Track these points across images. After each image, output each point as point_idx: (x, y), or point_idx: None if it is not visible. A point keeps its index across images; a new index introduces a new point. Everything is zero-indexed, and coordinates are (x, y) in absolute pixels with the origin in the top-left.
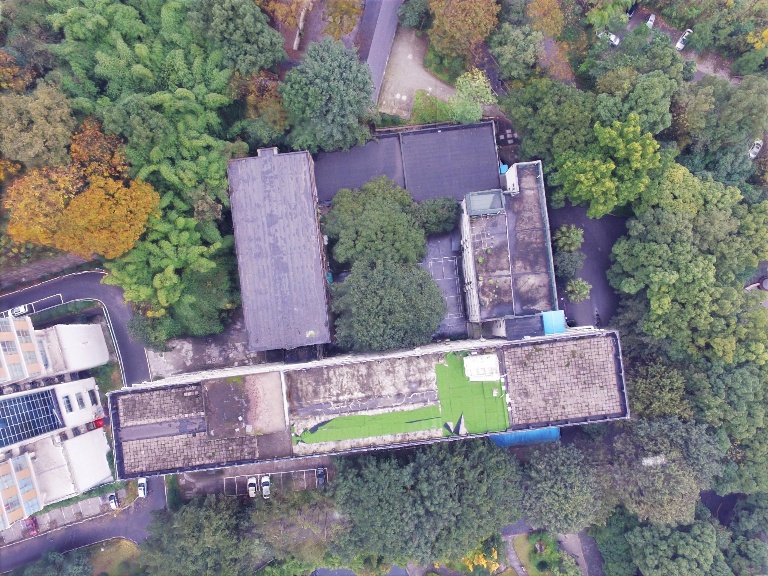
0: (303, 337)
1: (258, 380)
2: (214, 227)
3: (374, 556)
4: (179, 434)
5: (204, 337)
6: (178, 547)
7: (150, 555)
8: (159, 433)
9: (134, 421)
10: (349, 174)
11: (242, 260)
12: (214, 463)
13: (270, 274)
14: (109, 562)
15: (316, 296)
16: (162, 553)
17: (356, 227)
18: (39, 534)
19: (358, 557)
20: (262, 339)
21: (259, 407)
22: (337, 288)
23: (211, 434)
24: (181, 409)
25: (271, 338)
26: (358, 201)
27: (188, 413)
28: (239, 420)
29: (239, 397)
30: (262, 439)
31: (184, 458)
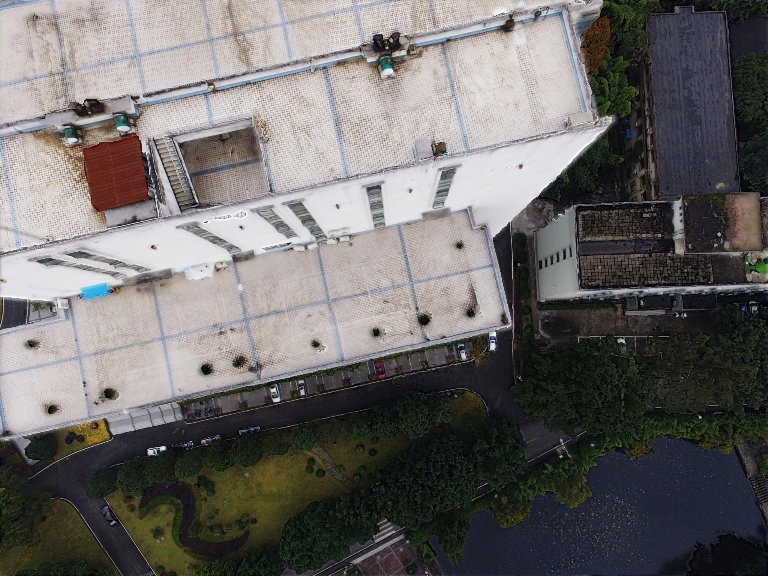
0: (713, 188)
1: (737, 199)
2: (626, 78)
3: (730, 424)
4: (635, 253)
5: (566, 199)
6: (597, 374)
7: (549, 387)
8: (614, 251)
9: (592, 237)
10: (738, 46)
11: (656, 110)
12: (670, 283)
13: (683, 125)
14: (452, 412)
15: (727, 150)
16: (563, 386)
17: (763, 89)
18: (385, 378)
19: (715, 423)
20: (673, 187)
21: (737, 225)
22: (746, 145)
23: (689, 247)
24: (638, 229)
25: (682, 186)
26: (765, 65)
27: (646, 233)
28: (718, 236)
29: (719, 214)
30: (716, 265)
31: (640, 276)
